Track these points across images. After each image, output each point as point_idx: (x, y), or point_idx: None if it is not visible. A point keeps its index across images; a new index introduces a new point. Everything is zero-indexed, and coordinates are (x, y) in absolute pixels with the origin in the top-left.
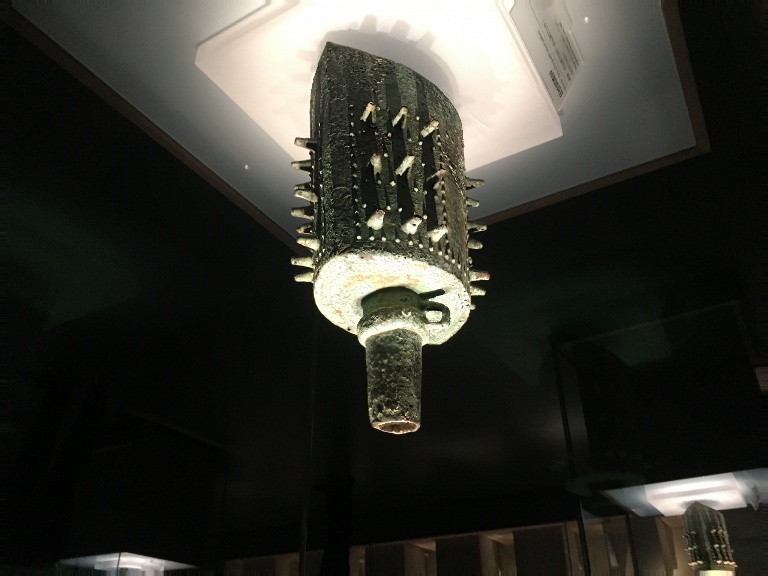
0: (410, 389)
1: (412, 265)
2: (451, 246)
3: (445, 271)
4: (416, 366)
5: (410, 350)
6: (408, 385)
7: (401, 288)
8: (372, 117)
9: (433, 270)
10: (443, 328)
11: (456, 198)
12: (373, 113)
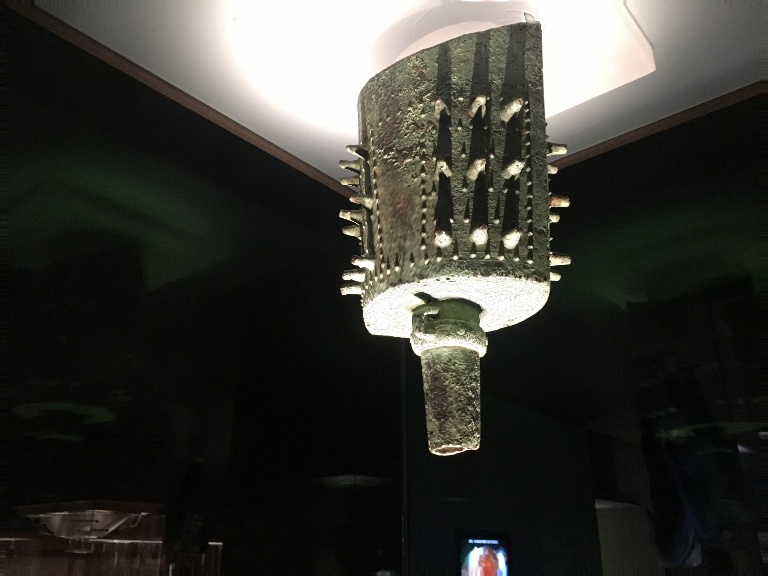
0: (429, 415)
1: (374, 308)
2: (387, 256)
3: (381, 293)
4: (433, 385)
5: (425, 373)
6: (427, 412)
7: (414, 311)
8: (354, 183)
9: (381, 298)
10: (421, 337)
11: (394, 185)
12: (351, 181)
